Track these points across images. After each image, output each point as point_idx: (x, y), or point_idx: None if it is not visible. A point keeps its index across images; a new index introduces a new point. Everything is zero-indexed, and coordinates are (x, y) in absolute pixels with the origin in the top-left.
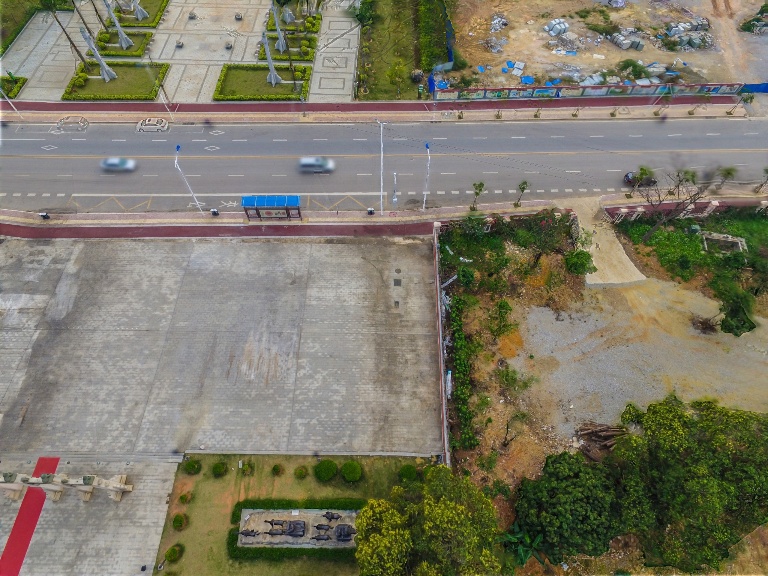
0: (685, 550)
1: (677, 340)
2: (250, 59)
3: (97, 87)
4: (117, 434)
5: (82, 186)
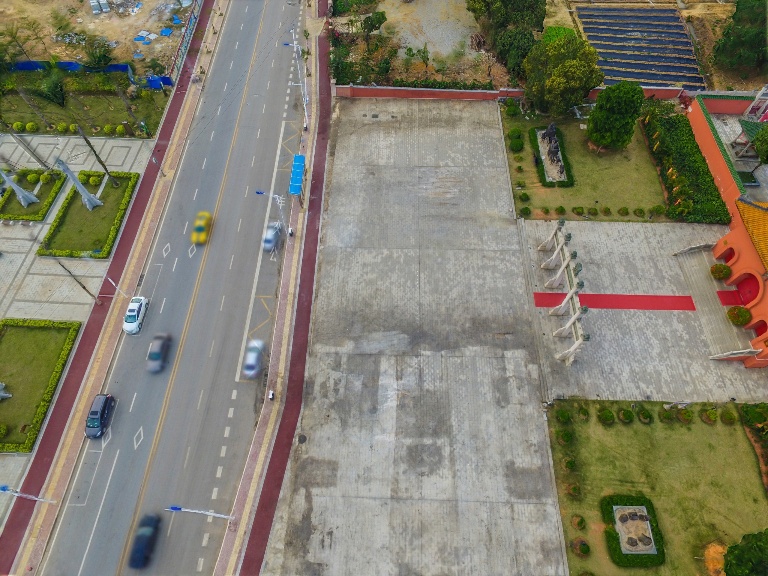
0: (542, 4)
1: (418, 10)
2: (35, 231)
3: (17, 408)
4: (509, 263)
5: (224, 373)
